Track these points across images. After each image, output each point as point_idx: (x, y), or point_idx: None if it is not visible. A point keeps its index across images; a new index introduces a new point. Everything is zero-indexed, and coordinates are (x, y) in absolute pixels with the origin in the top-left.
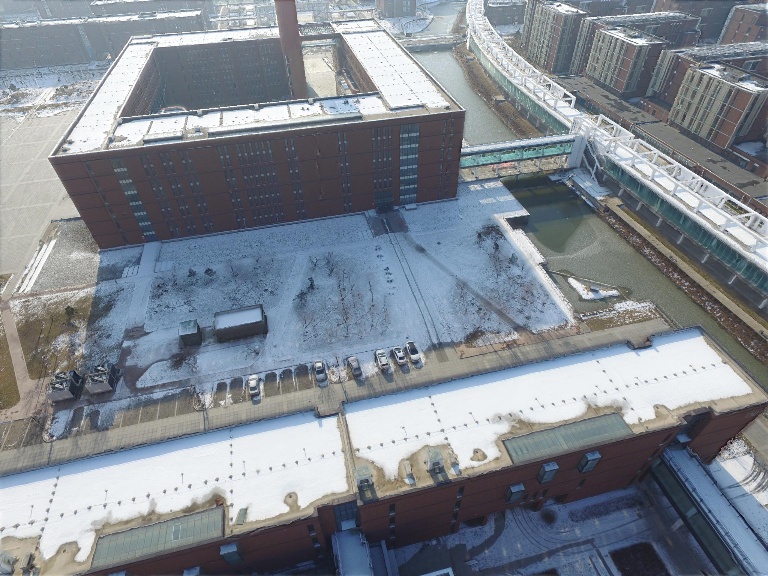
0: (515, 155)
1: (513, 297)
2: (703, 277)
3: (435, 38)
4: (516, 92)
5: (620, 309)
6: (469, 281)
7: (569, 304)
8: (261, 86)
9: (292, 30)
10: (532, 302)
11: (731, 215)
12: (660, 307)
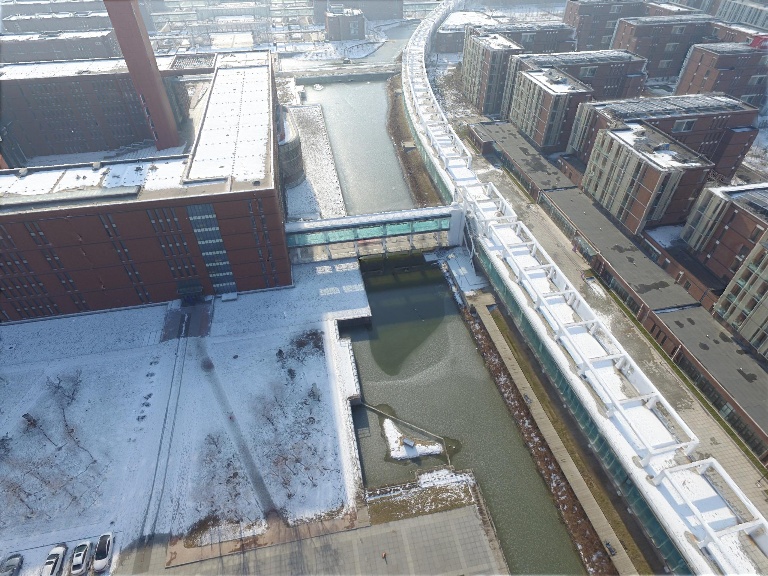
0: (379, 230)
1: (286, 457)
2: (559, 431)
3: (373, 66)
4: (418, 142)
5: (425, 485)
6: (244, 423)
7: (358, 472)
8: (128, 125)
9: (143, 66)
10: (308, 467)
11: (602, 347)
12: (479, 485)
